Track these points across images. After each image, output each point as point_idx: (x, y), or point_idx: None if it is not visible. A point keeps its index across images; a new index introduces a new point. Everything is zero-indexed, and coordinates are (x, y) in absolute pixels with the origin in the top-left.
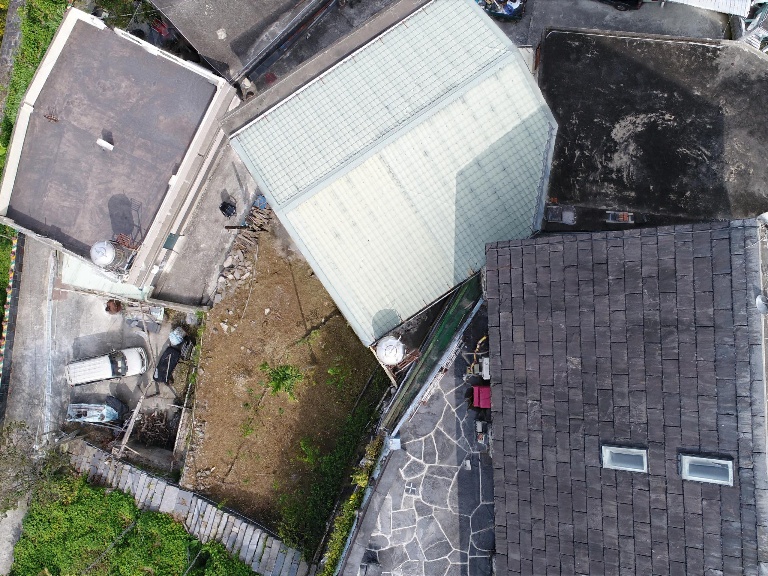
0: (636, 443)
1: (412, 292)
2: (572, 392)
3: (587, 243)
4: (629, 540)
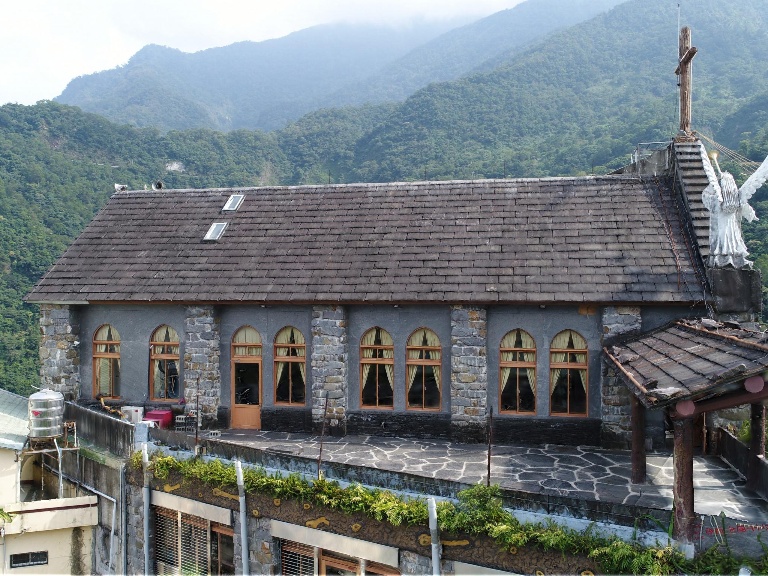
0: (208, 228)
1: (9, 427)
2: (161, 254)
3: (73, 247)
4: (268, 232)
